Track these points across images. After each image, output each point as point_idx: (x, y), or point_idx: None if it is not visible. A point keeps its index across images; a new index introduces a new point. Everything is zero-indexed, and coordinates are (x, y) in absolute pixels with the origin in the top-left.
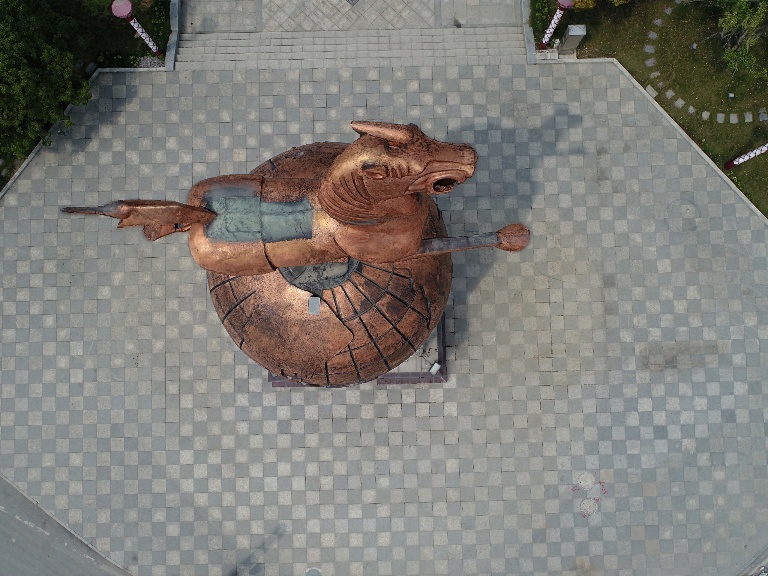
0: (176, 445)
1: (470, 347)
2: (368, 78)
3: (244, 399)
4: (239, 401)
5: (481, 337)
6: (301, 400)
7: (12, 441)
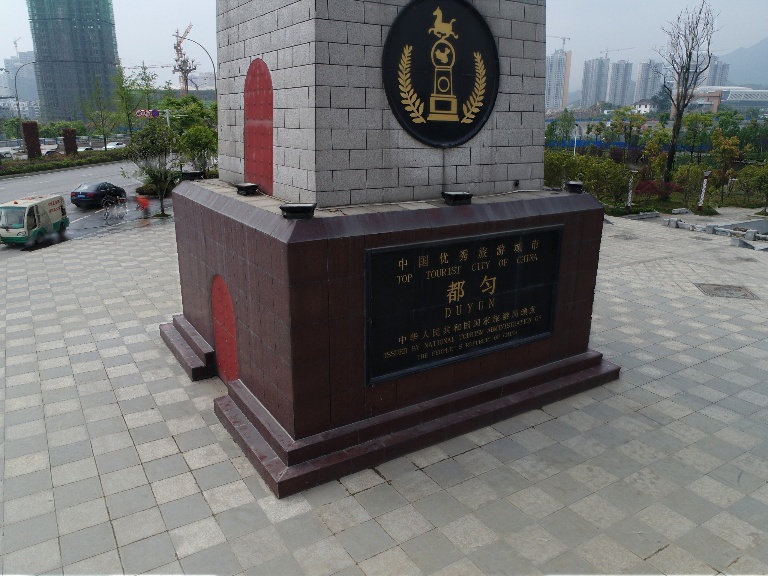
0: (41, 307)
1: (409, 506)
2: (661, 295)
3: (130, 325)
4: (125, 323)
5: (455, 516)
6: (144, 358)
7: (42, 259)
